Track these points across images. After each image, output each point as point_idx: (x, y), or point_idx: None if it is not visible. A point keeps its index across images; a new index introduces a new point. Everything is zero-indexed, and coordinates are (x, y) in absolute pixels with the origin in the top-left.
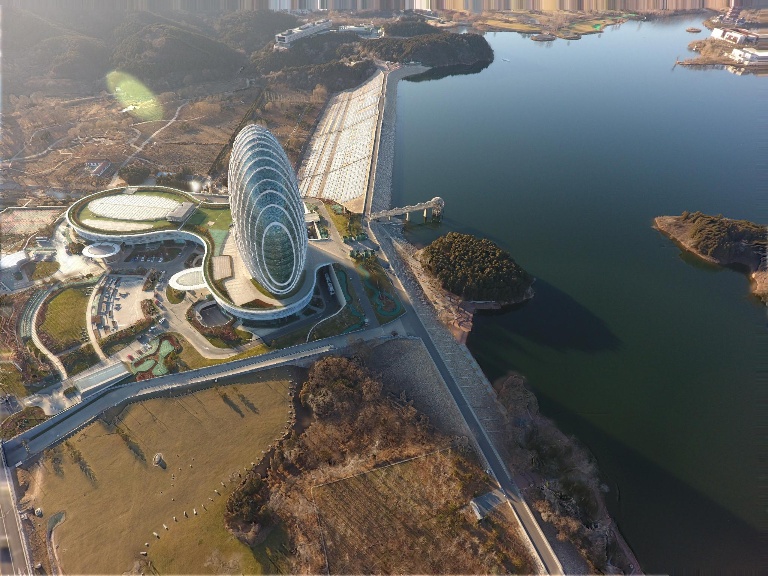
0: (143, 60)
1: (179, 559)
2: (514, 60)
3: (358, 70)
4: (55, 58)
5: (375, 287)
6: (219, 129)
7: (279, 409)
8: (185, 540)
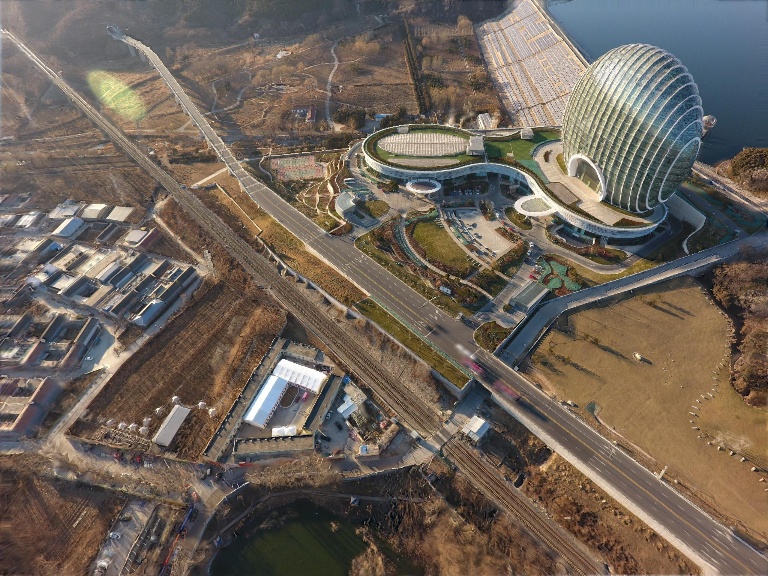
0: (274, 2)
1: (731, 430)
2: None
3: None
4: (180, 6)
5: (721, 201)
6: (390, 68)
7: (709, 311)
8: (723, 416)
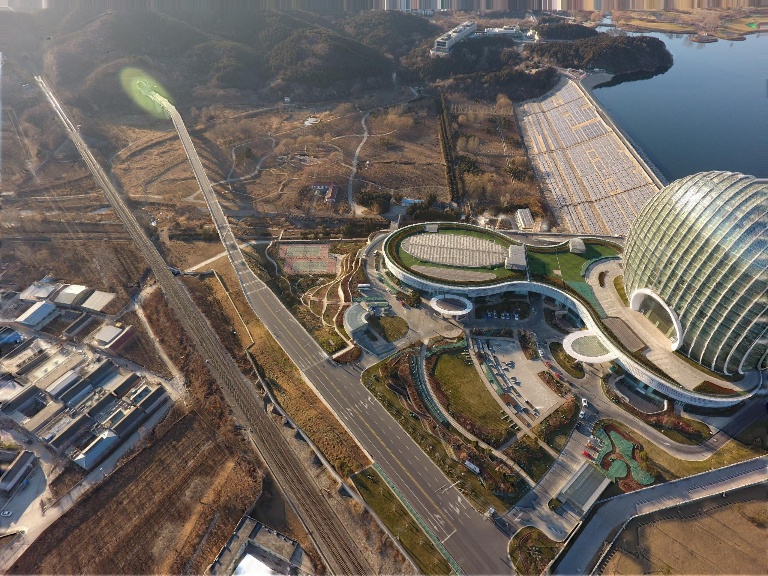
0: (308, 68)
1: None
2: (694, 65)
3: (542, 78)
4: (215, 66)
5: None
6: (423, 146)
7: None
8: None
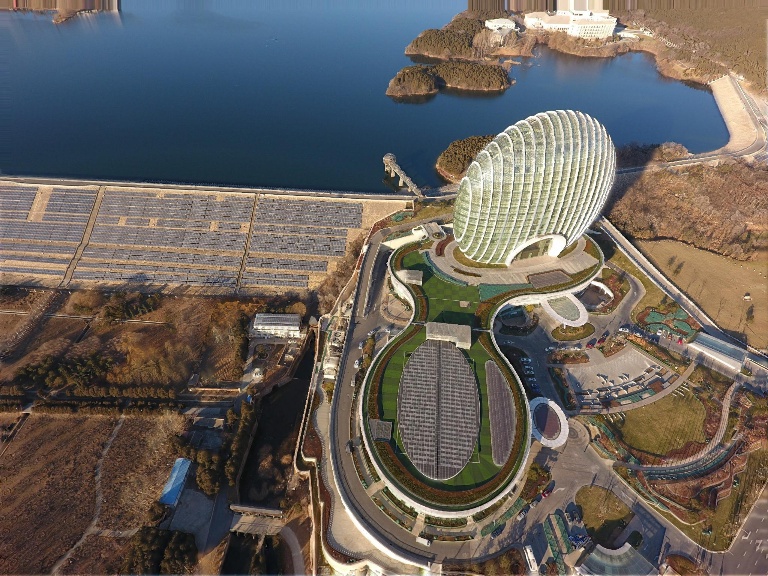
0: None
1: None
2: None
3: None
4: None
5: None
6: None
7: (666, 246)
8: None
